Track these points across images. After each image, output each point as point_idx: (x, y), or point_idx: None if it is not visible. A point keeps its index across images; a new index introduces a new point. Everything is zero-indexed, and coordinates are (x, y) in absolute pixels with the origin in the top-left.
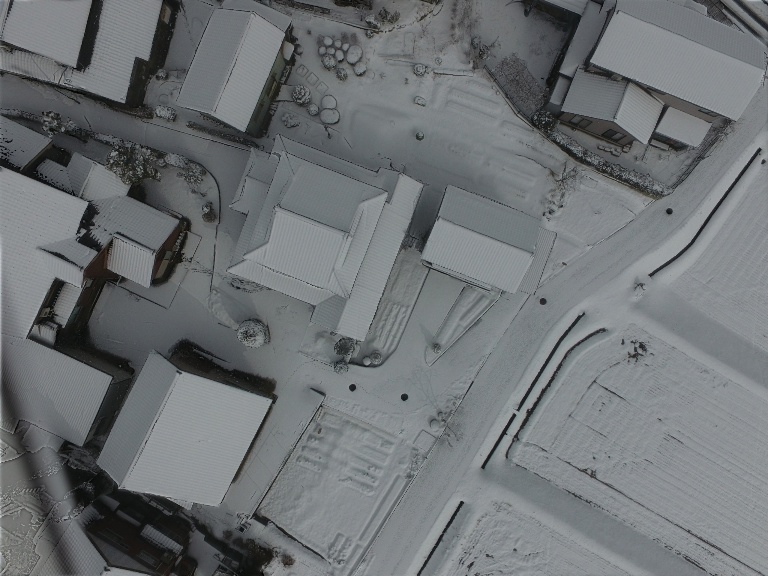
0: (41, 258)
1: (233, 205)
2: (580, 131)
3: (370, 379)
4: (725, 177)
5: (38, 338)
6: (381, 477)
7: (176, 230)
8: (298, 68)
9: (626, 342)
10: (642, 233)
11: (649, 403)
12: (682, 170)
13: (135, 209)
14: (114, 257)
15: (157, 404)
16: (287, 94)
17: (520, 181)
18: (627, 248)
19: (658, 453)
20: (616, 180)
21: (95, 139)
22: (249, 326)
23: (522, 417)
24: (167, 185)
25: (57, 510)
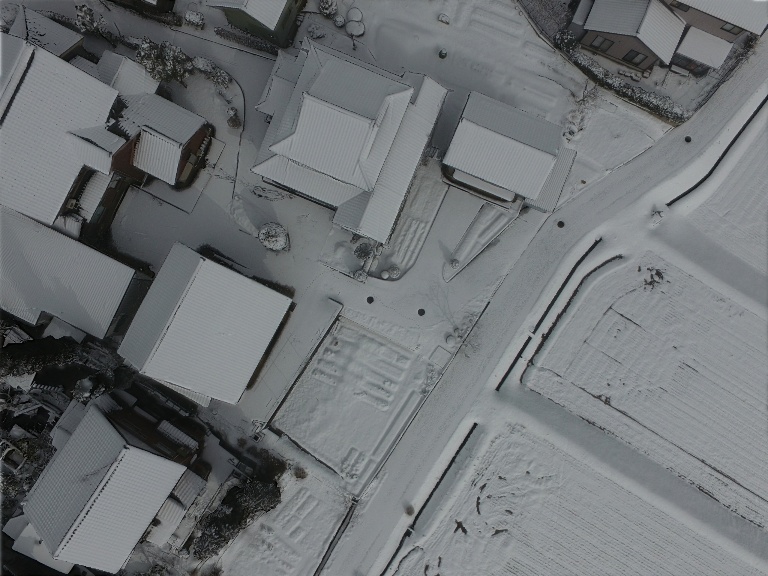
0: (71, 143)
1: (259, 106)
2: (601, 56)
3: (388, 292)
4: (744, 108)
5: (63, 231)
6: (396, 392)
7: (201, 133)
8: None
9: (643, 269)
10: (660, 160)
11: (665, 331)
12: (702, 96)
13: (163, 106)
14: (141, 152)
15: (180, 291)
16: (314, 6)
17: (541, 101)
18: (645, 174)
19: (673, 381)
20: (636, 105)
21: (124, 44)
22: (271, 227)
23: (537, 341)
24: (193, 92)
25: (79, 386)
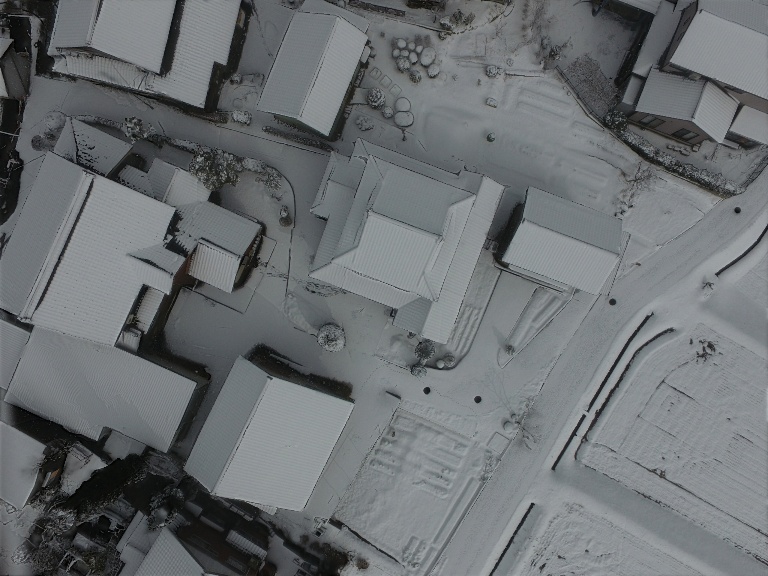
0: (130, 265)
1: (314, 209)
2: (649, 131)
3: (444, 382)
4: None
5: (121, 345)
6: (455, 480)
7: None
8: (372, 71)
9: (694, 342)
10: (710, 232)
11: (718, 402)
12: (752, 169)
13: (217, 214)
14: (197, 263)
15: (247, 410)
16: (361, 97)
17: (591, 182)
18: (696, 247)
19: (727, 452)
20: (685, 179)
21: (170, 144)
22: (330, 330)
23: (591, 418)
24: (242, 190)
25: (154, 517)
